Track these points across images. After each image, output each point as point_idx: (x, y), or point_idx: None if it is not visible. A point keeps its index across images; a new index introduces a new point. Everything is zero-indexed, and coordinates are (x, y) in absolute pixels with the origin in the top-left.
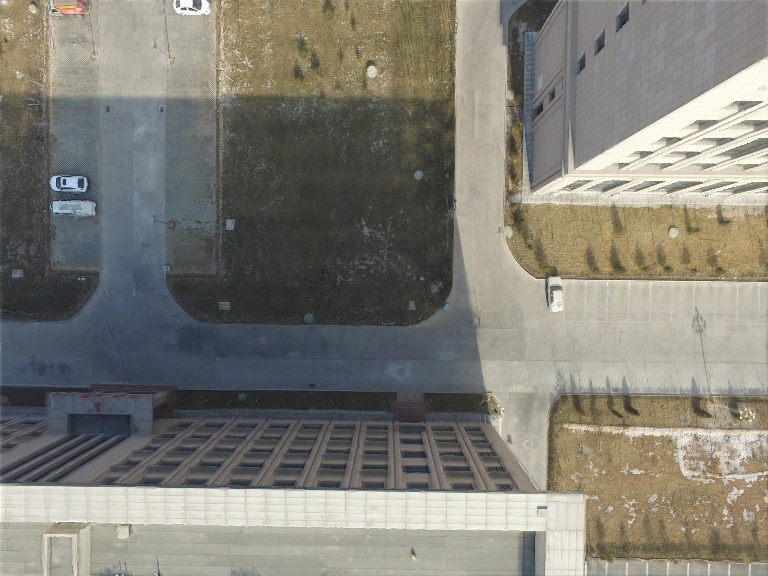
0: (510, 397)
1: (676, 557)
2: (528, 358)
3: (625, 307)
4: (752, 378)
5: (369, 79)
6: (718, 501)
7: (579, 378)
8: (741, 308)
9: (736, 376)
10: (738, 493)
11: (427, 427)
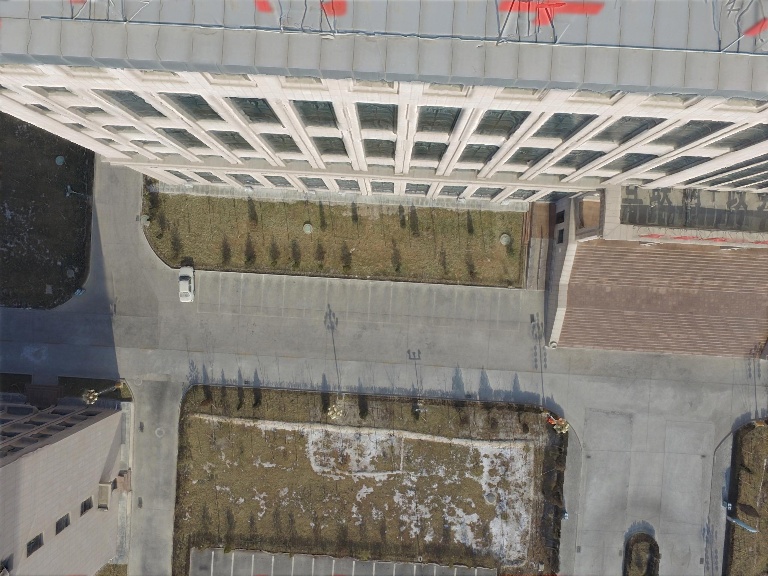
0: (143, 385)
1: (299, 552)
2: (162, 347)
3: (258, 300)
4: (382, 377)
5: None
6: (347, 498)
7: (211, 369)
8: (373, 307)
9: (366, 374)
10: (367, 491)
11: (47, 410)
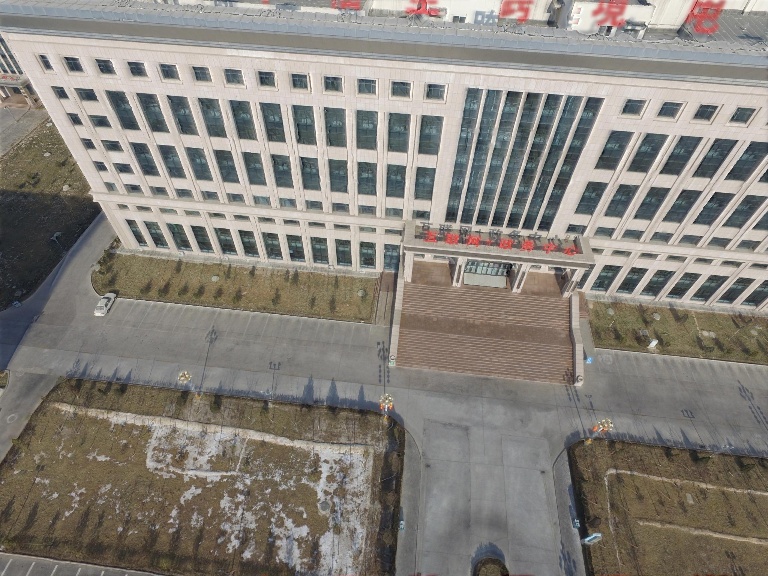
0: (23, 376)
1: (91, 558)
2: (59, 347)
3: (158, 320)
4: (242, 382)
5: (63, 191)
6: (170, 499)
7: (92, 367)
8: (249, 329)
9: (228, 379)
10: (195, 492)
11: None
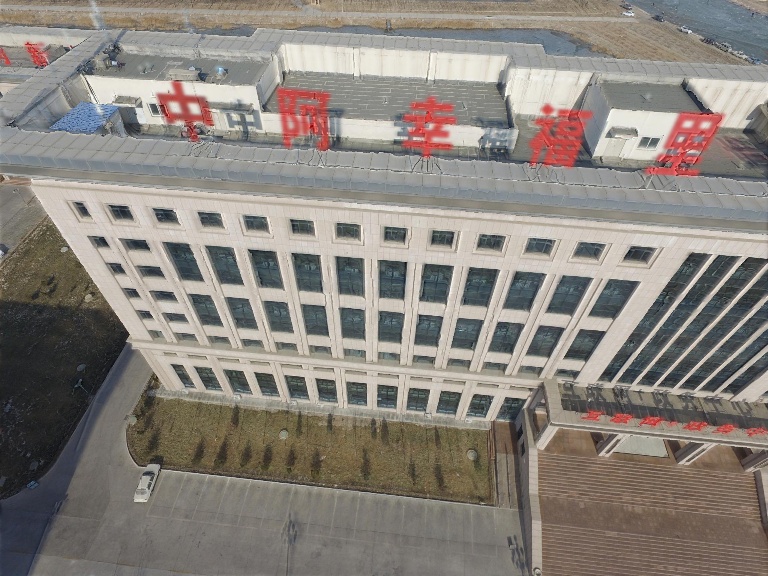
0: None
1: None
2: (89, 557)
3: (216, 506)
4: None
5: (85, 303)
6: None
7: None
8: (337, 519)
9: None
10: None
11: None
